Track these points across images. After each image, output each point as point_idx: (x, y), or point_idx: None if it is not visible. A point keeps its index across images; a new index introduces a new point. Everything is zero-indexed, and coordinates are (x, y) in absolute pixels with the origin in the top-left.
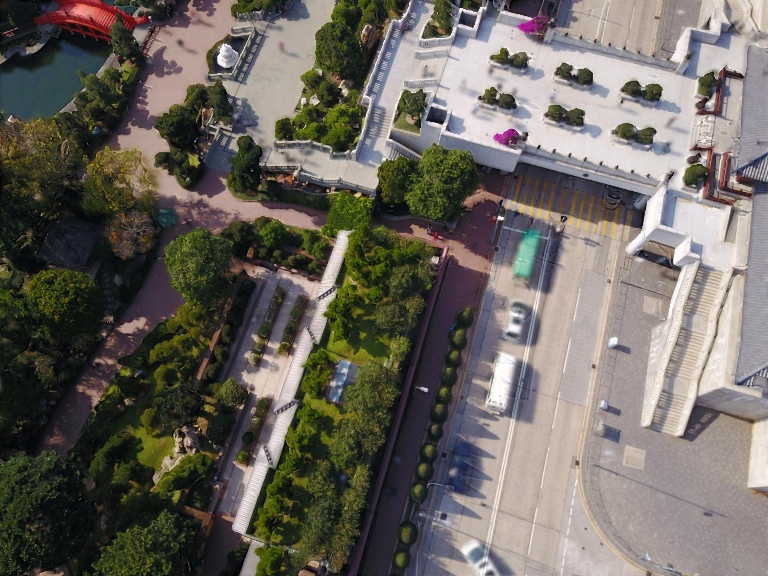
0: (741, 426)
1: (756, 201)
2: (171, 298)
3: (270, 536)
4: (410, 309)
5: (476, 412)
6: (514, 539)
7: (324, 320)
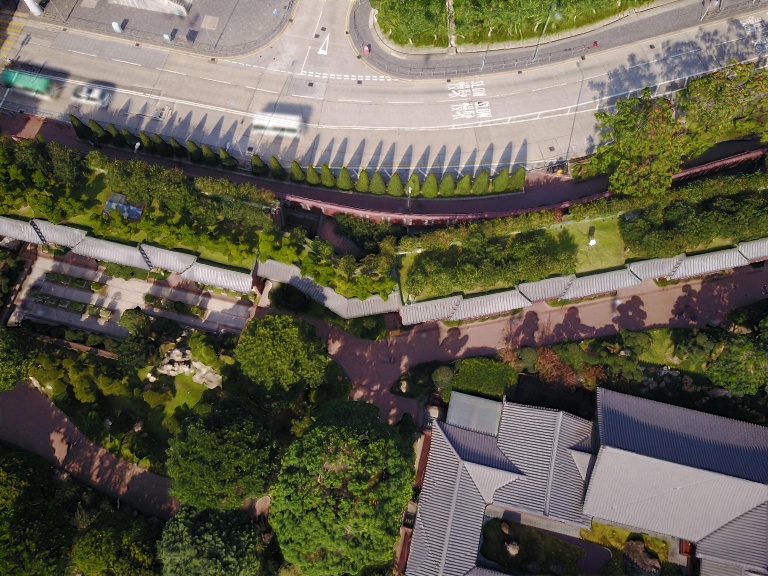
0: None
1: None
2: (32, 409)
3: (251, 252)
4: None
5: (169, 127)
6: (267, 102)
7: (65, 231)
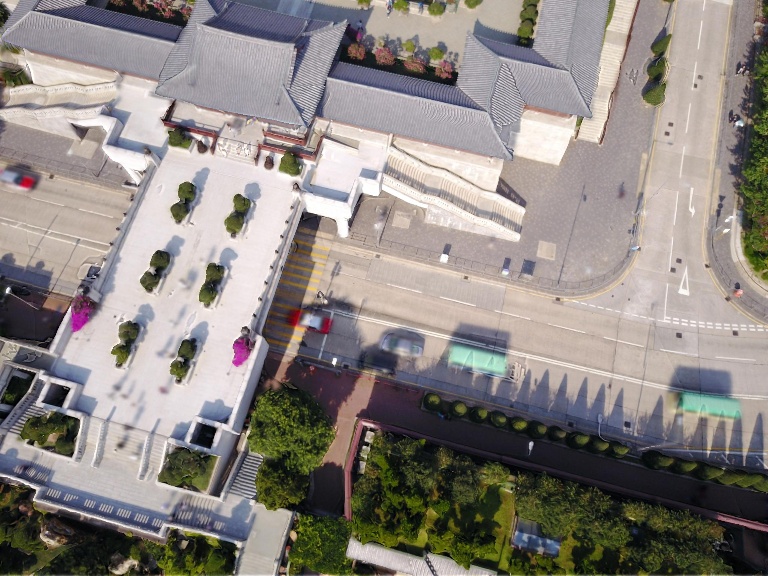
0: (508, 163)
1: (330, 117)
2: None
3: None
4: (446, 464)
5: (524, 392)
6: (634, 359)
7: None
